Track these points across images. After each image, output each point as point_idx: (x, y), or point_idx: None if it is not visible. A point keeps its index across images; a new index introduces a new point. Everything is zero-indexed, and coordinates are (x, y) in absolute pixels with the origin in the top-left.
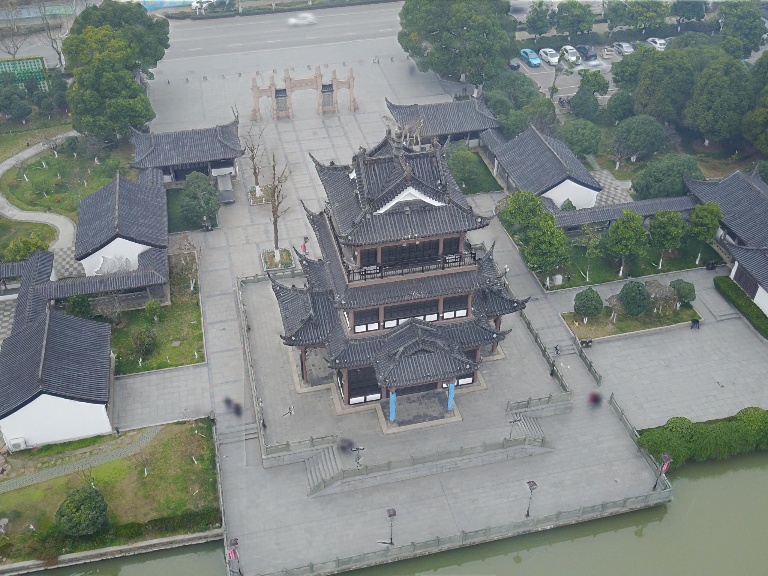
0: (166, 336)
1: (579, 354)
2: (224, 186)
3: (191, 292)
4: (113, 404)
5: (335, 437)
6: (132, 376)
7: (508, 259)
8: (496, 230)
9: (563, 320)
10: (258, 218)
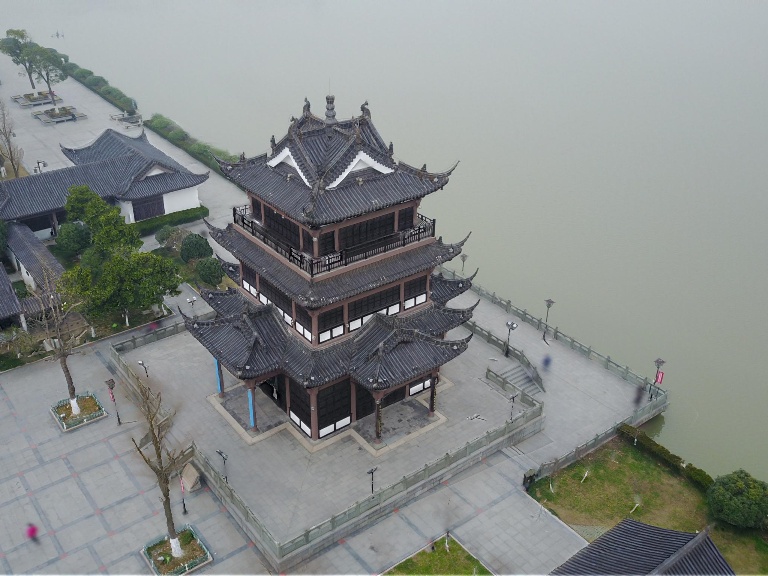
0: None
1: None
2: None
3: None
4: None
5: (488, 372)
6: None
7: None
8: (47, 365)
9: None
10: None
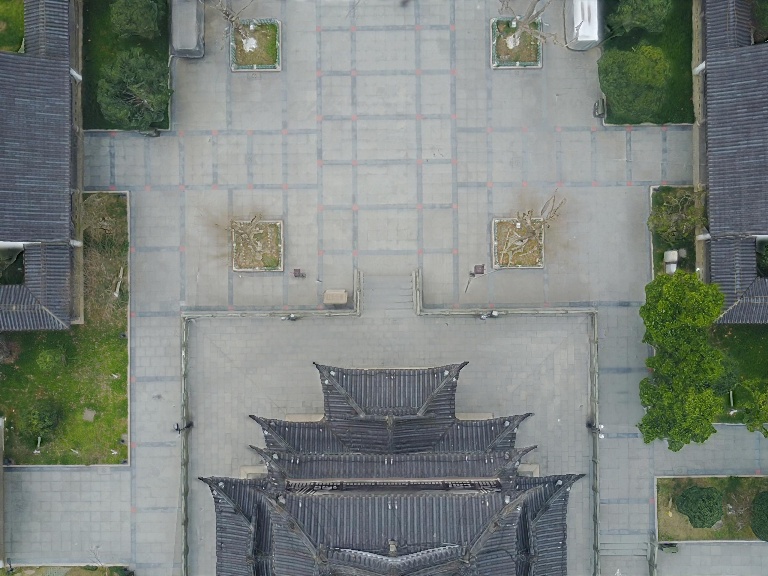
0: (75, 396)
1: (649, 561)
2: (181, 38)
3: (115, 301)
4: (3, 518)
5: None
6: (28, 468)
7: (628, 327)
8: (637, 242)
9: (655, 493)
10: (240, 114)
